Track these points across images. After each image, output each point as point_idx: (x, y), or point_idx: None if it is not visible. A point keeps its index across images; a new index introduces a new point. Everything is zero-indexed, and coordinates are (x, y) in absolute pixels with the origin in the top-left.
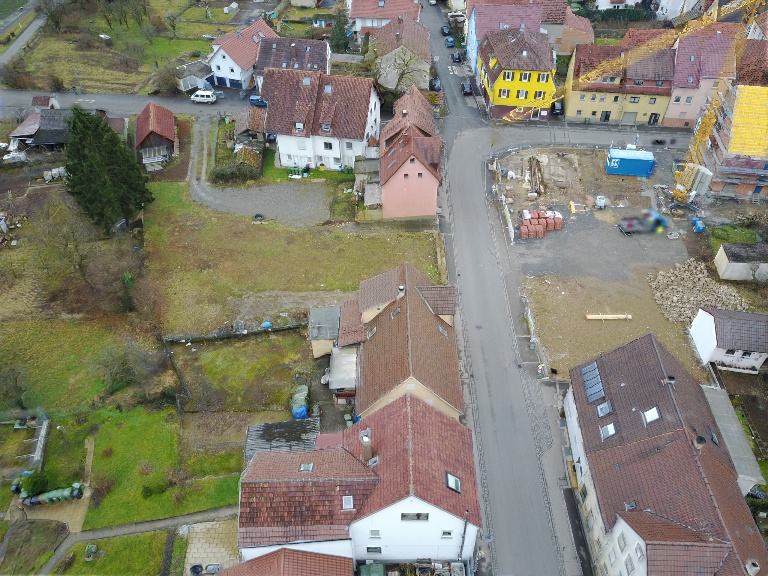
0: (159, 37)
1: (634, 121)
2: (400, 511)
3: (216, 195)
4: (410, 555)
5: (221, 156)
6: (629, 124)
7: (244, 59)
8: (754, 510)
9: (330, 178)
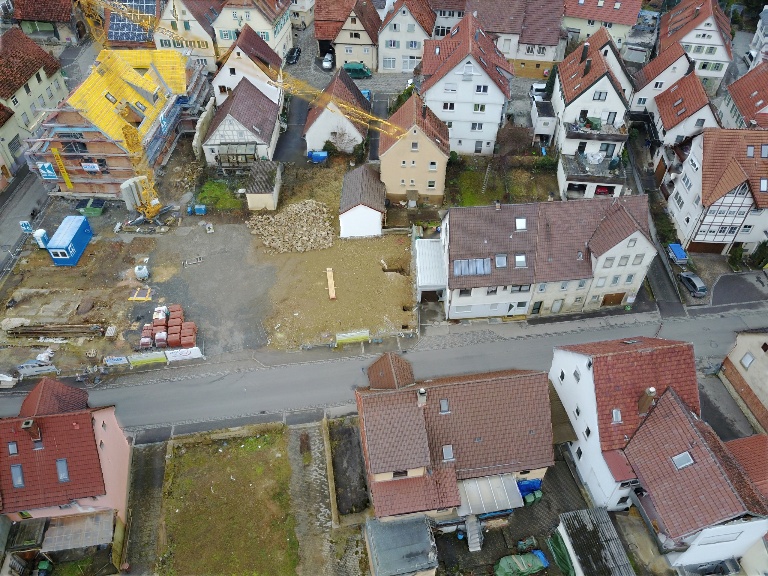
0: None
1: None
2: None
3: None
4: None
5: None
6: None
7: None
8: None
9: None
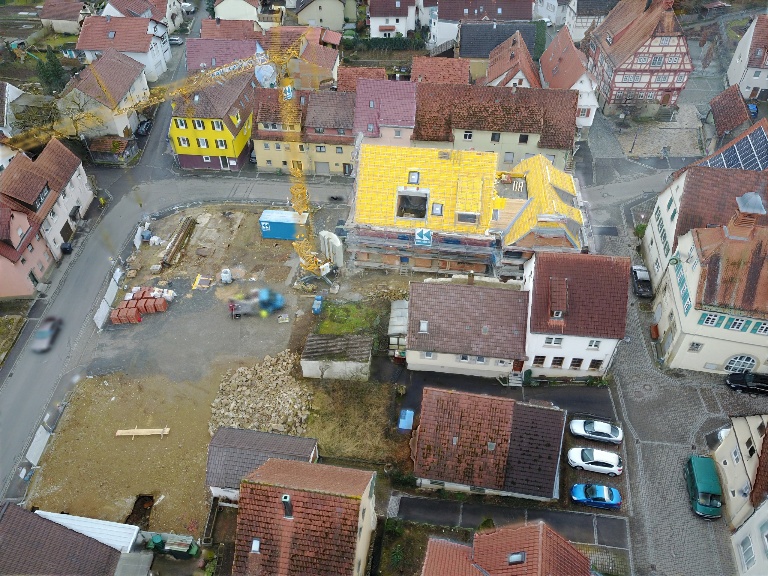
0: None
1: (329, 171)
2: None
3: None
4: None
5: None
6: (324, 174)
7: None
8: None
9: None
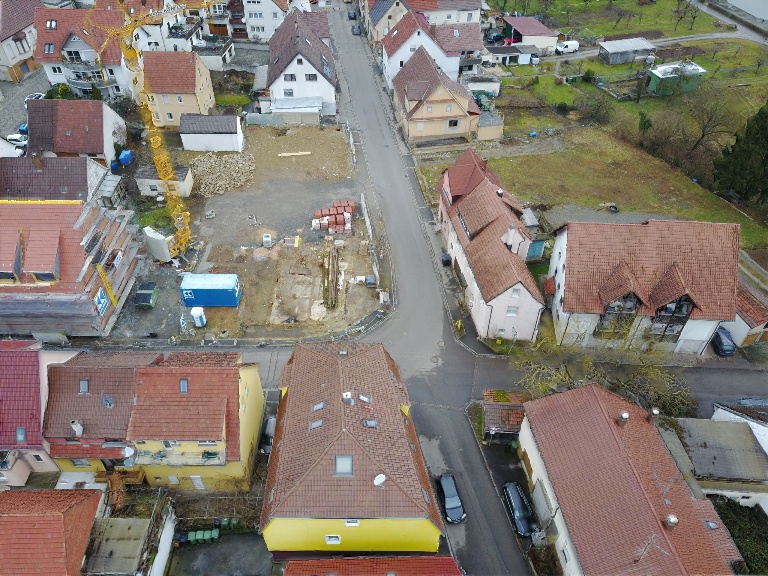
0: None
1: None
2: None
3: None
4: None
5: None
6: None
7: None
8: None
9: None
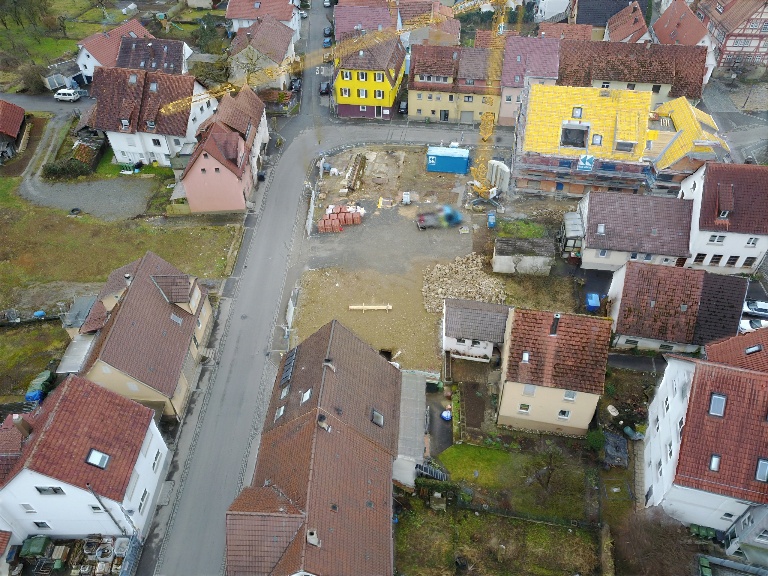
0: (50, 37)
1: (472, 120)
2: (31, 484)
3: (44, 190)
4: (80, 530)
5: (64, 152)
6: (468, 123)
7: (109, 58)
8: (431, 490)
9: (159, 174)
